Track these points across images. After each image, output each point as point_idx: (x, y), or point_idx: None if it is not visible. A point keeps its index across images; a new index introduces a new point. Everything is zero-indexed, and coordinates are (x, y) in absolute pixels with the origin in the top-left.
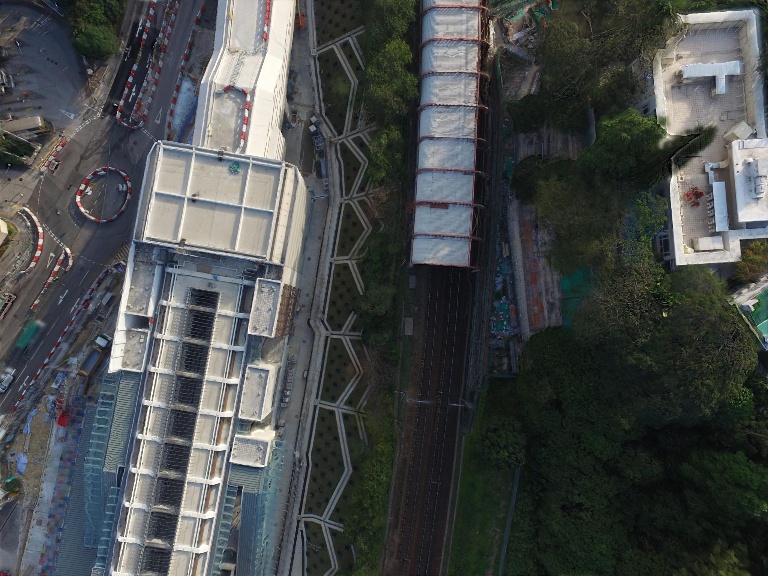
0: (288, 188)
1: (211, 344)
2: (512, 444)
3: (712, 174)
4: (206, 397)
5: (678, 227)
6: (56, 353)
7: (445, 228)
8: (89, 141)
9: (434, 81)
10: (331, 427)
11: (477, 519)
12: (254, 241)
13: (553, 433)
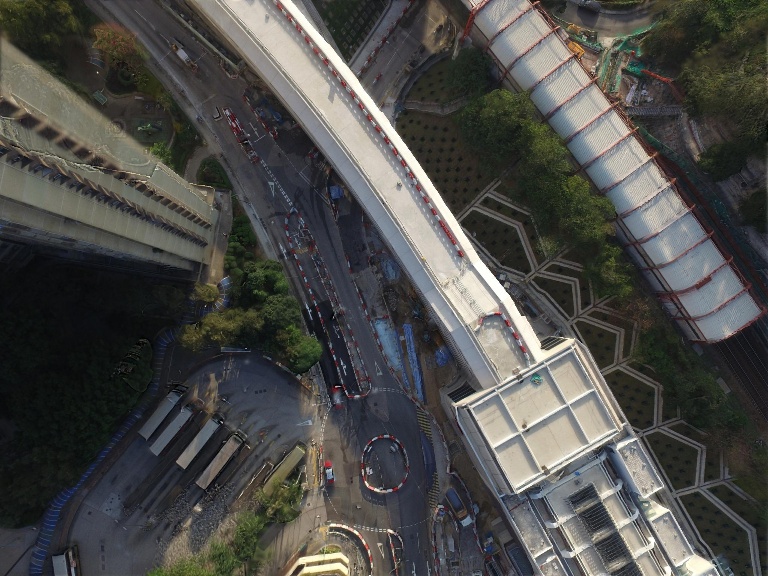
0: (585, 361)
1: (618, 529)
2: None
3: None
4: (646, 573)
5: None
6: None
7: (721, 296)
8: (339, 432)
9: (622, 189)
10: (705, 506)
11: None
12: (595, 424)
13: None
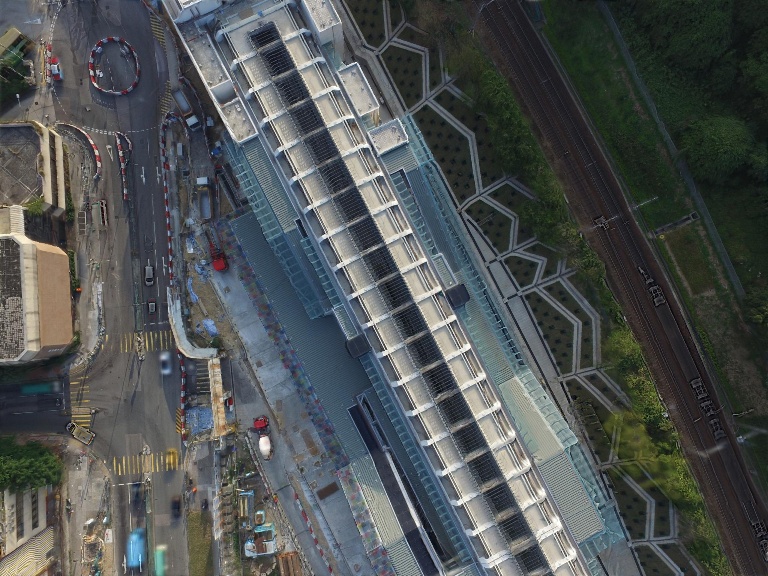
0: None
1: (296, 66)
2: None
3: None
4: (323, 111)
5: None
6: (172, 222)
7: None
8: (68, 32)
9: None
10: (433, 119)
11: (598, 80)
12: None
13: None
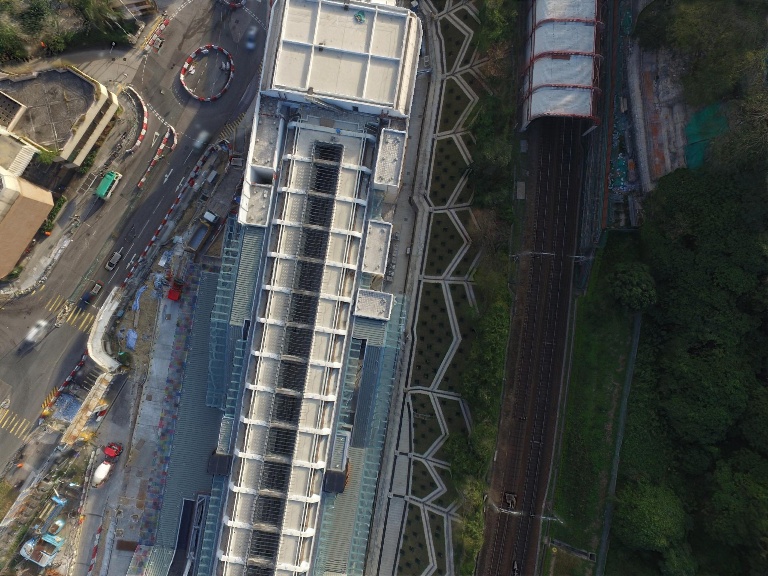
0: (412, 38)
1: (336, 196)
2: (645, 281)
3: None
4: (332, 248)
5: None
6: (163, 230)
7: (567, 79)
8: (191, 20)
9: None
10: (437, 299)
11: (593, 377)
12: (380, 90)
13: (684, 272)
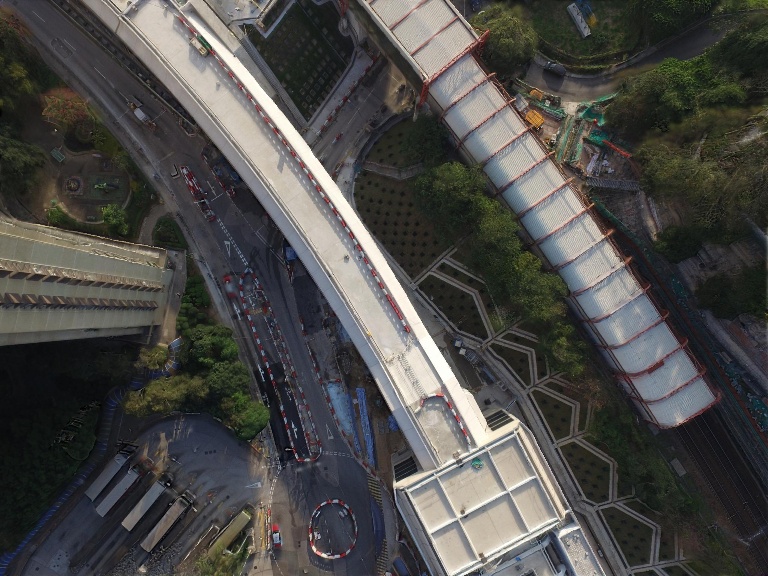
0: (528, 446)
1: None
2: None
3: None
4: None
5: None
6: None
7: (673, 382)
8: (288, 495)
9: (574, 268)
10: None
11: None
12: (536, 511)
13: None
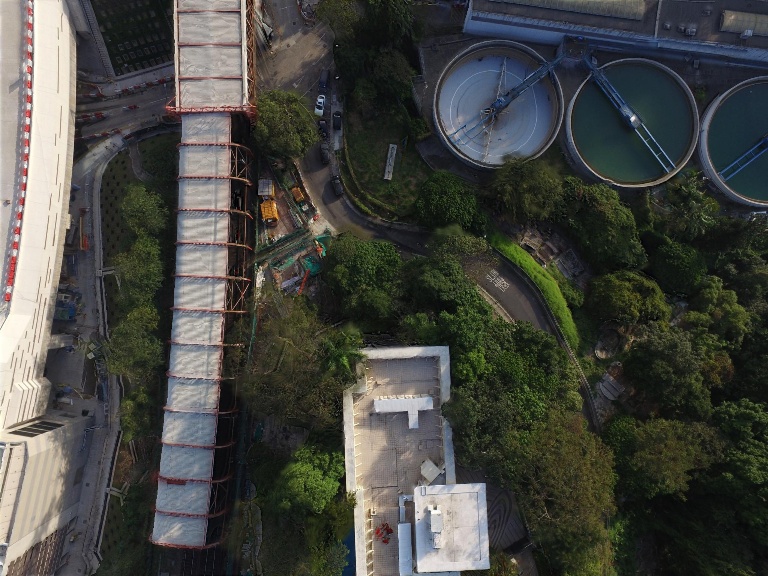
0: (15, 466)
1: None
2: None
3: (404, 509)
4: None
5: (361, 570)
6: None
7: (181, 505)
8: None
9: (177, 351)
10: None
11: None
12: None
13: None
